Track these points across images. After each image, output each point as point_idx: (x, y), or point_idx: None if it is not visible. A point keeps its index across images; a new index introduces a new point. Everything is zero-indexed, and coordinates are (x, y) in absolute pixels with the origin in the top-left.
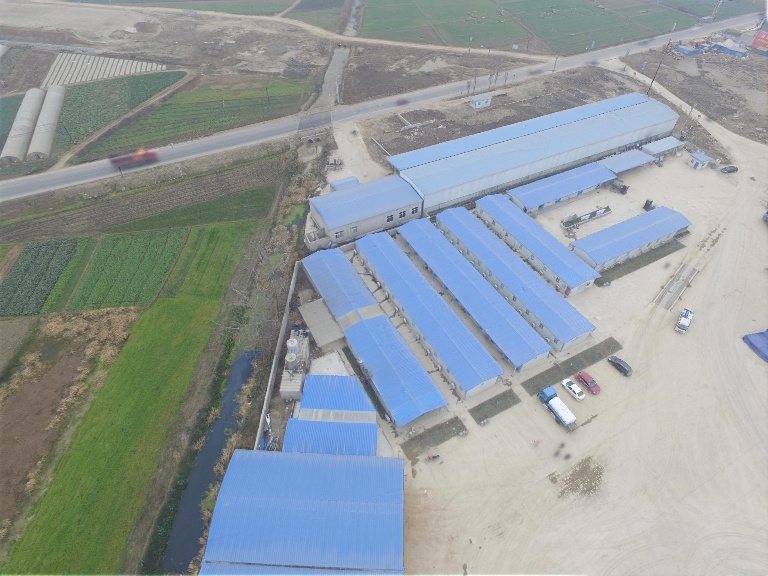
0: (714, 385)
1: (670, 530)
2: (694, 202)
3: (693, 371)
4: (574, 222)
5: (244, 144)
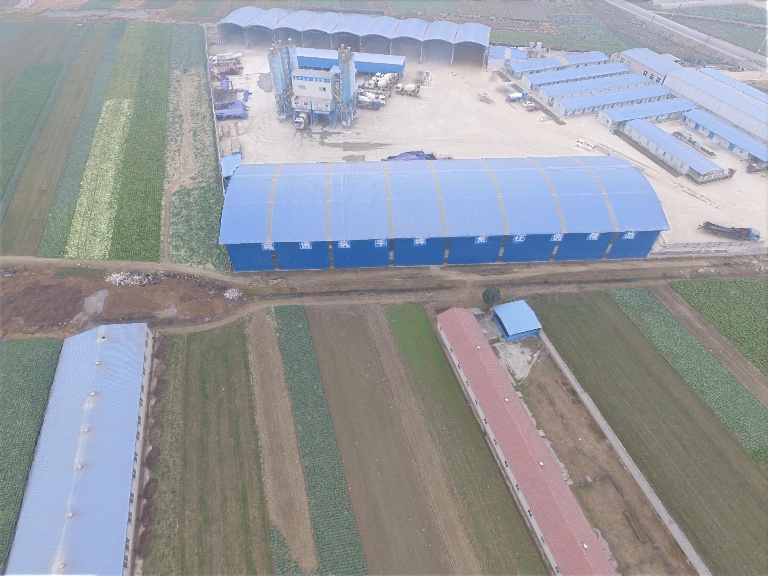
0: (537, 143)
1: (464, 110)
2: (759, 207)
3: (546, 140)
4: (682, 136)
5: (712, 46)
